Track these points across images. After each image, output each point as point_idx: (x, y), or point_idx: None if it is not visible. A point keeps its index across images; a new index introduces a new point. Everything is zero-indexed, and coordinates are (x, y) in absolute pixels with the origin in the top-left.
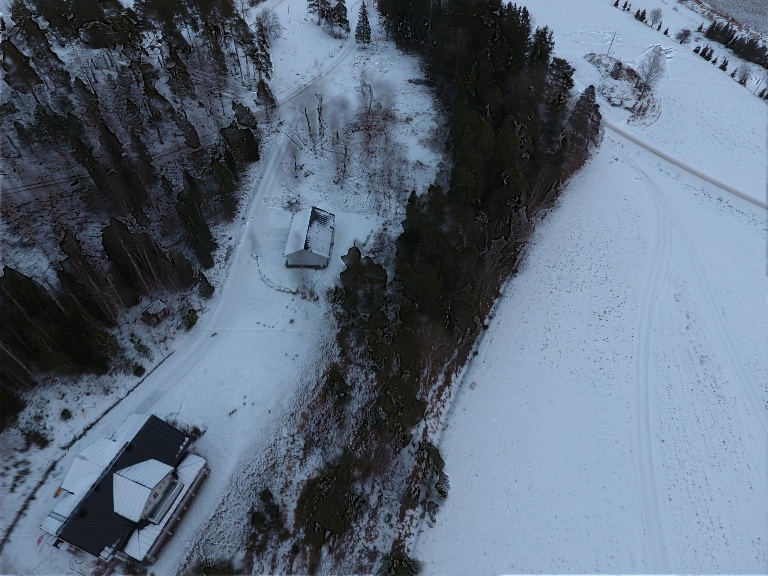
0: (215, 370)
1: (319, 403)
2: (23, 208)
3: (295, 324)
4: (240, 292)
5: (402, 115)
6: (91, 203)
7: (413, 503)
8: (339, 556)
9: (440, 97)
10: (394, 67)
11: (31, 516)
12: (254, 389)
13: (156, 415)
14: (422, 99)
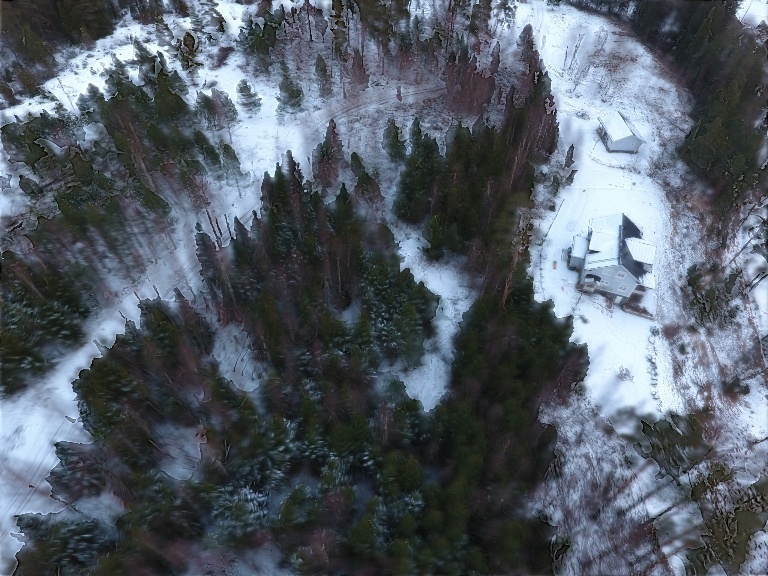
0: (602, 209)
1: (675, 233)
2: (413, 107)
3: (637, 186)
4: (583, 167)
5: (626, 56)
6: (452, 106)
7: (748, 301)
8: (720, 323)
9: (644, 45)
10: (591, 23)
11: (547, 277)
12: (637, 220)
13: (582, 231)
14: (633, 46)
